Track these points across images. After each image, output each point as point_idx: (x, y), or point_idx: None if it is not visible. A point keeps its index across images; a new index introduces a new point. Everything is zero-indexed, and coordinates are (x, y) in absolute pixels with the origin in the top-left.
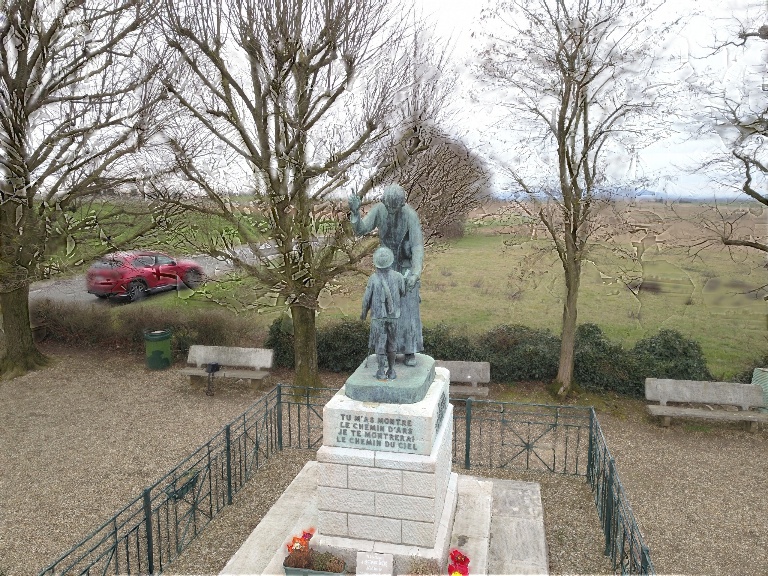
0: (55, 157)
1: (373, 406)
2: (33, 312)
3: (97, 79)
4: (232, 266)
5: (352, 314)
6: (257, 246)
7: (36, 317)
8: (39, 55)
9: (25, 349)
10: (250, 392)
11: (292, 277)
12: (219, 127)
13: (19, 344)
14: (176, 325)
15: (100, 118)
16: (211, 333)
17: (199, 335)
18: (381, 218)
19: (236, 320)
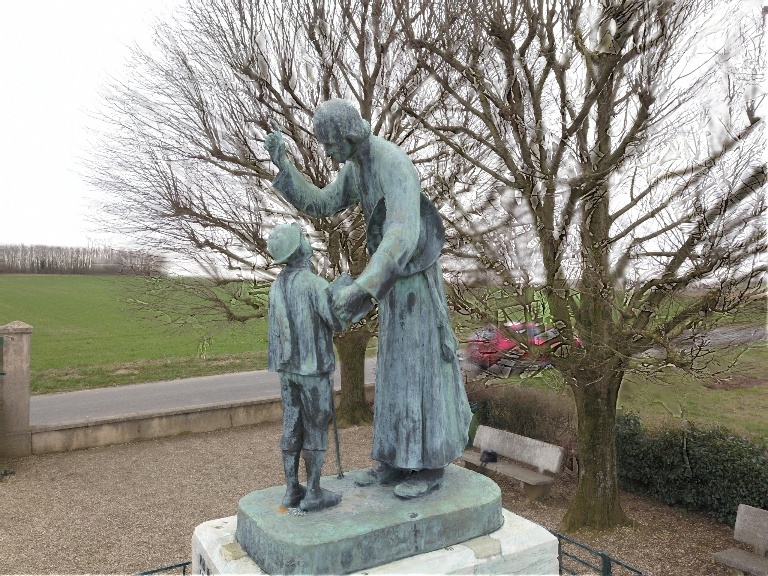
0: (360, 212)
1: (227, 556)
2: (368, 368)
3: (433, 139)
4: (477, 322)
5: (709, 418)
6: (480, 292)
7: (370, 373)
8: (382, 125)
9: (354, 403)
10: (525, 500)
11: (535, 339)
12: (468, 149)
13: (349, 397)
14: (493, 401)
15: (445, 179)
16: (522, 416)
17: (511, 416)
18: (355, 179)
19: (554, 404)
